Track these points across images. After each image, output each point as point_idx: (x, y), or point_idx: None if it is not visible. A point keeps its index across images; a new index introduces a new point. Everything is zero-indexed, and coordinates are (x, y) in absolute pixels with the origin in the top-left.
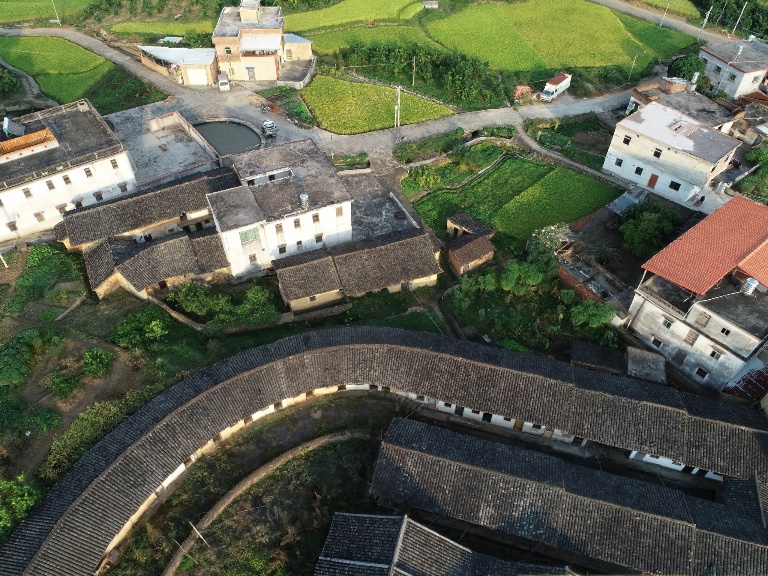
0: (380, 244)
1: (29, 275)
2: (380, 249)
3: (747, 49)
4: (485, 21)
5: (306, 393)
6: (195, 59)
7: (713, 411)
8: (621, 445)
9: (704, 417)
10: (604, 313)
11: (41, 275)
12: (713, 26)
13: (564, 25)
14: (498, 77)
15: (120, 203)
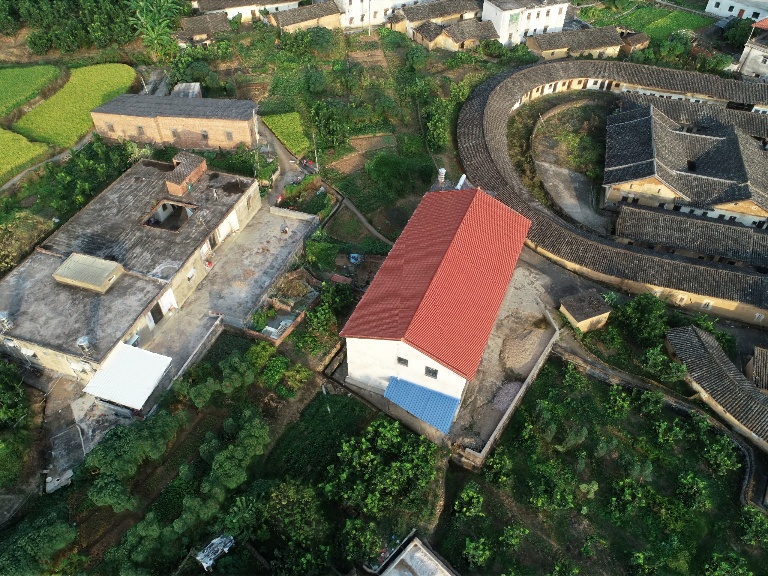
0: None
1: (386, 38)
2: (587, 31)
3: None
4: None
5: (567, 86)
6: None
7: None
8: (747, 102)
9: None
10: (726, 59)
11: (393, 38)
12: None
13: None
14: None
15: (430, 3)
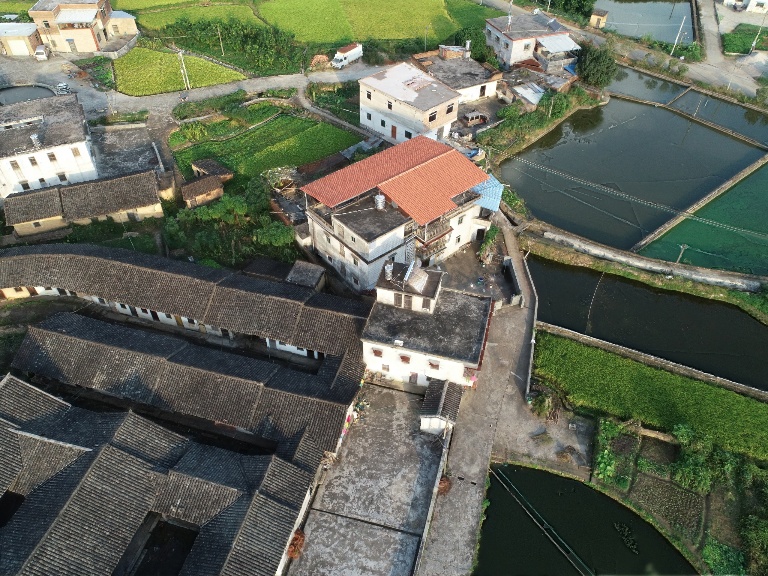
0: None
1: None
2: (106, 183)
3: (528, 21)
4: (317, 1)
5: None
6: None
7: (333, 305)
8: (244, 331)
9: None
10: (282, 233)
11: None
12: (531, 5)
13: (388, 4)
14: (305, 48)
15: None
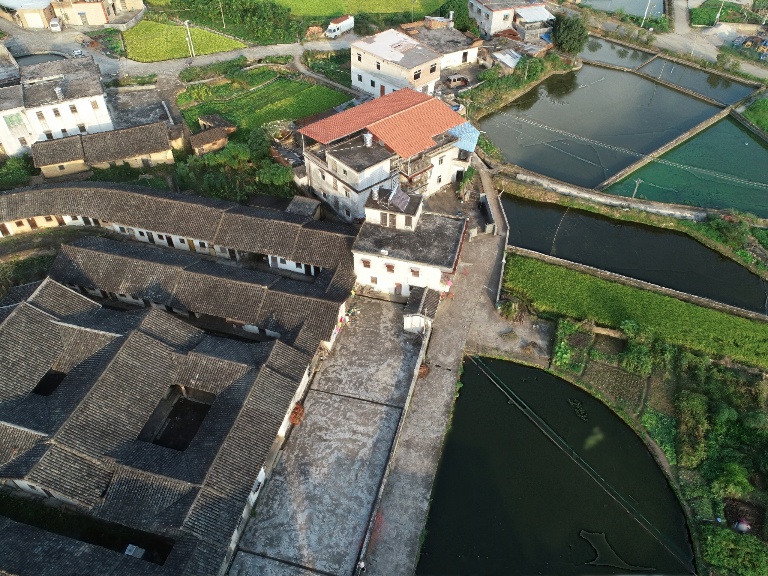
0: (125, 129)
1: None
2: (123, 132)
3: None
4: None
5: (30, 225)
6: (28, 4)
7: (328, 228)
8: (249, 249)
9: (314, 229)
10: (281, 172)
11: None
12: None
13: None
14: (301, 21)
15: None
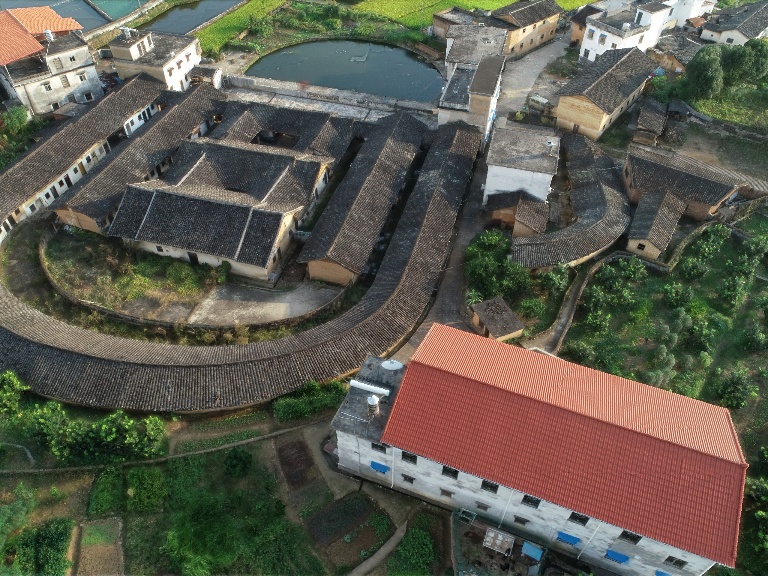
0: None
1: None
2: None
3: None
4: None
5: None
6: None
7: None
8: (121, 124)
9: (120, 90)
10: (20, 110)
11: None
12: None
13: None
14: None
15: None
